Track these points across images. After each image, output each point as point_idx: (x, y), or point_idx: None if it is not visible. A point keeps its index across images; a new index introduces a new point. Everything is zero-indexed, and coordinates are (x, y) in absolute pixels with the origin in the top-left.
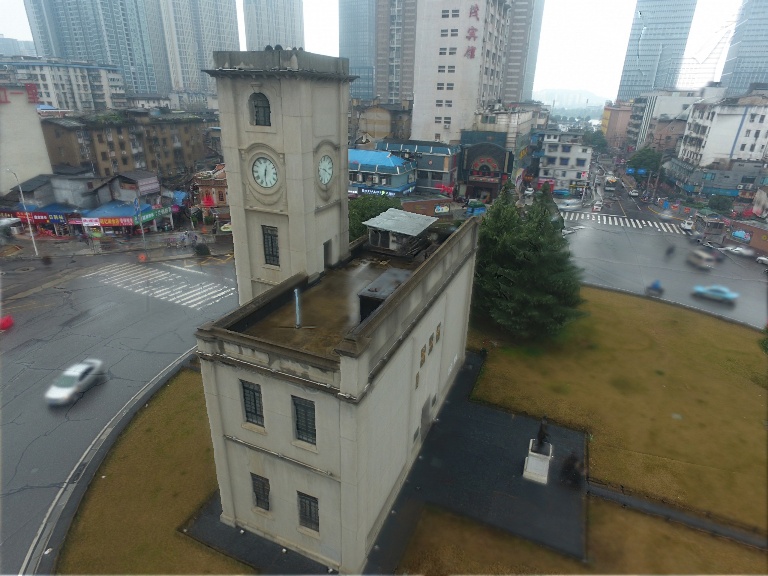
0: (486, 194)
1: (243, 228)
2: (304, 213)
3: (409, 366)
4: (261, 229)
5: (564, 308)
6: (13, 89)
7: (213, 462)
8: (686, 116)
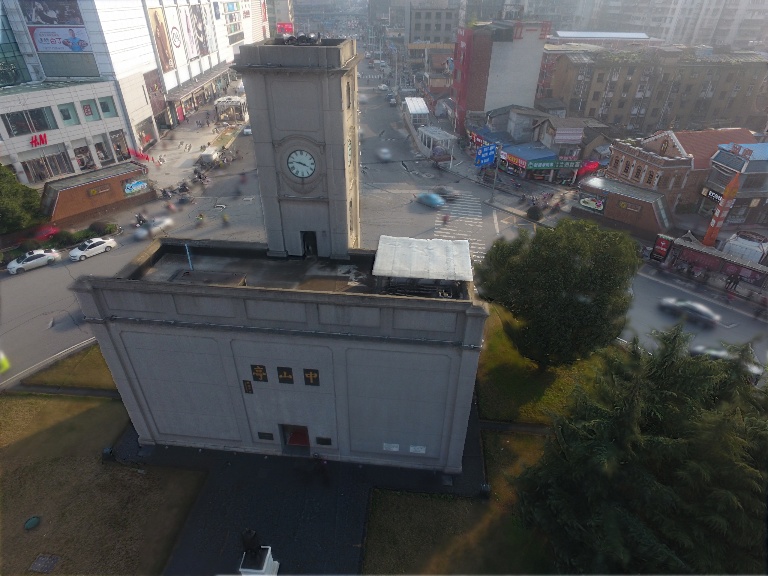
0: None
1: None
2: (261, 195)
3: (216, 360)
4: None
5: (599, 572)
6: (531, 26)
7: None
8: None
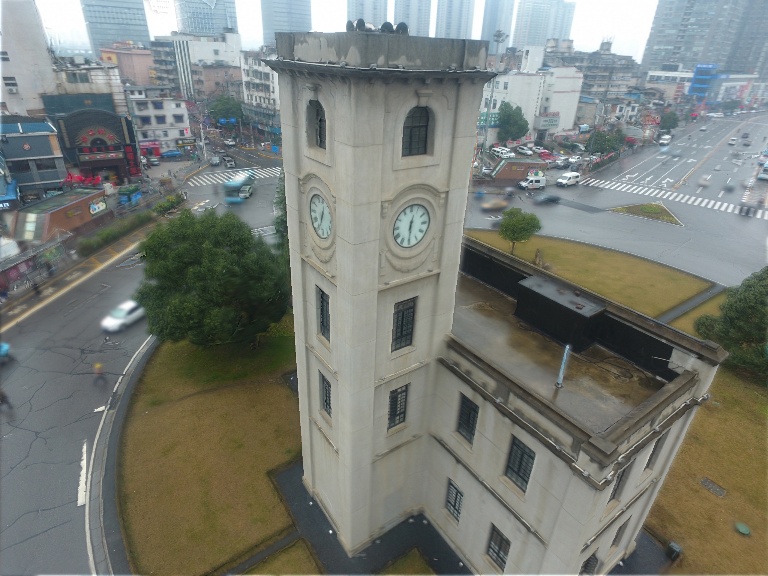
0: (106, 174)
1: (373, 320)
2: None
3: None
4: (393, 309)
5: None
6: None
7: None
8: (238, 63)
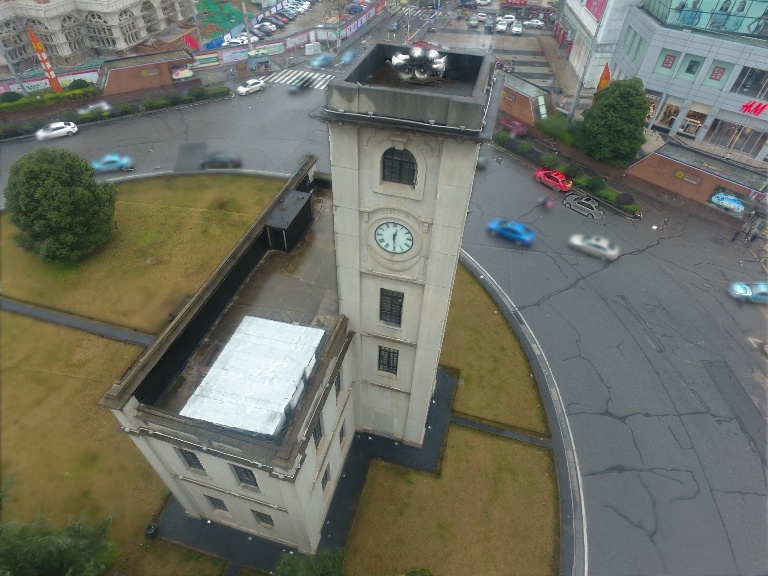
0: None
1: None
2: None
3: None
4: None
5: None
6: None
7: None
8: None
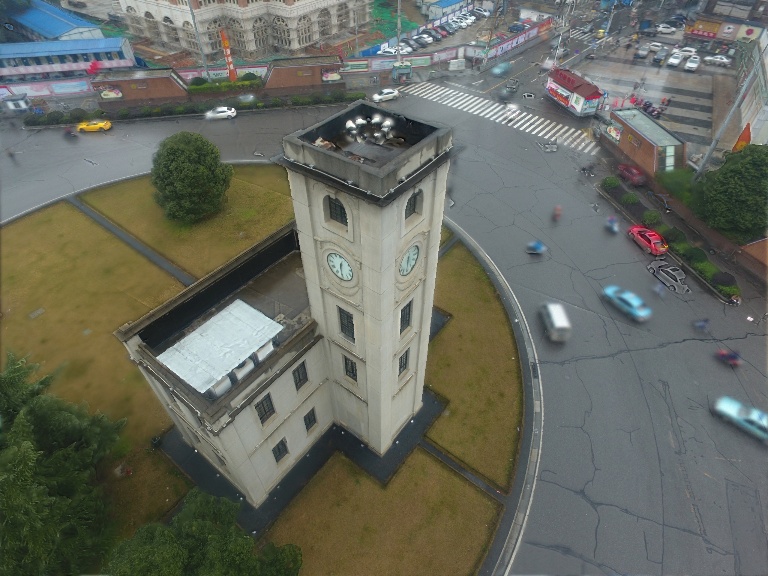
0: None
1: None
2: None
3: None
4: None
5: None
6: None
7: (443, 355)
8: None
